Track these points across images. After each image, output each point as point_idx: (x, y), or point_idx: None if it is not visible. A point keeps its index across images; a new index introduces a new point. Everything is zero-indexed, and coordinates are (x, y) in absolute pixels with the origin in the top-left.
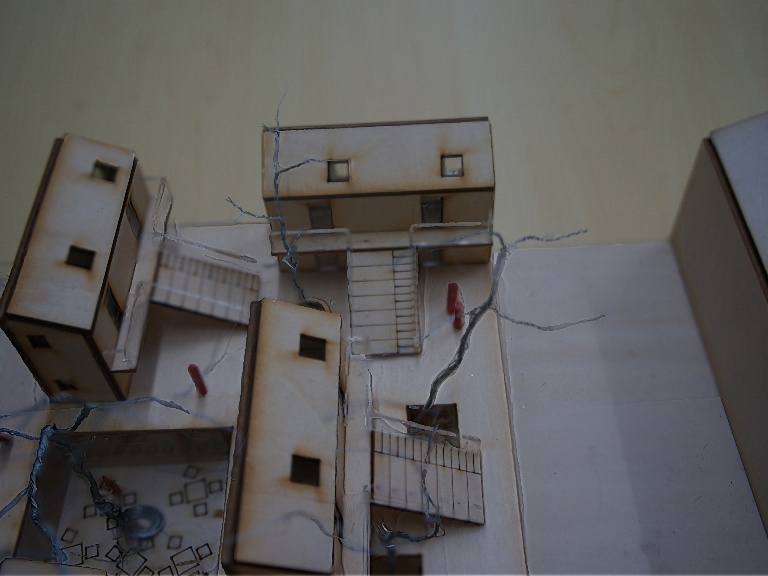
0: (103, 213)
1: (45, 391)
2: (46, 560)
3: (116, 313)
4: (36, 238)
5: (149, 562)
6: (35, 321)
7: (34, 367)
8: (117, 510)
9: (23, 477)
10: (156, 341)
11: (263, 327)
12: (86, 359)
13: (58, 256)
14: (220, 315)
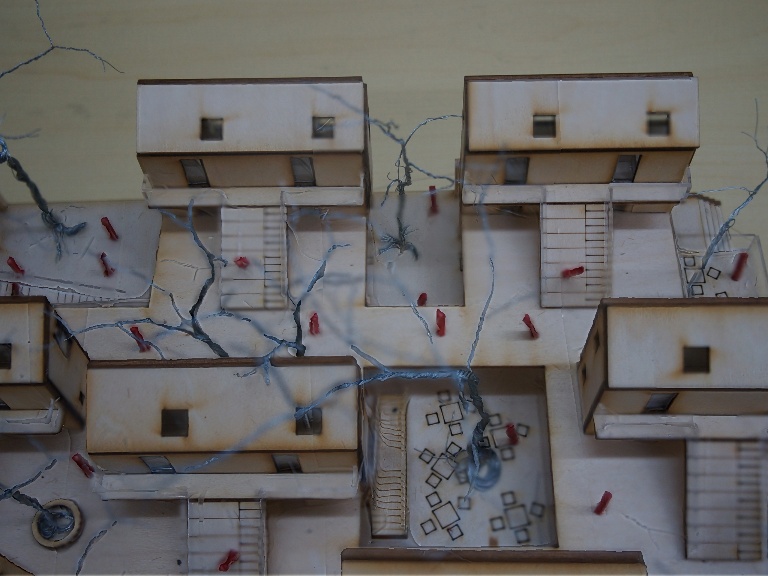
0: (766, 370)
1: (581, 356)
2: (448, 392)
3: (660, 407)
4: (707, 311)
5: (445, 482)
6: (606, 334)
7: (588, 342)
8: (496, 444)
9: (499, 357)
10: (656, 452)
11: (604, 568)
12: (595, 388)
13: (691, 338)
14: (690, 518)
